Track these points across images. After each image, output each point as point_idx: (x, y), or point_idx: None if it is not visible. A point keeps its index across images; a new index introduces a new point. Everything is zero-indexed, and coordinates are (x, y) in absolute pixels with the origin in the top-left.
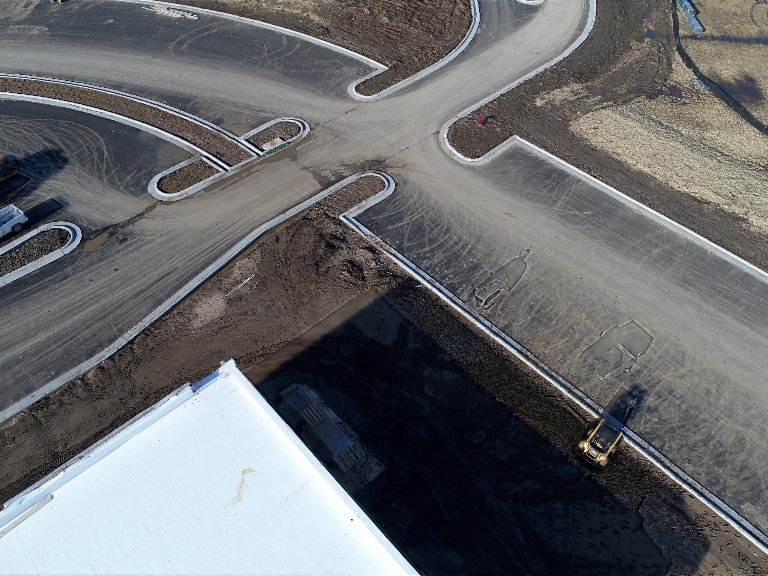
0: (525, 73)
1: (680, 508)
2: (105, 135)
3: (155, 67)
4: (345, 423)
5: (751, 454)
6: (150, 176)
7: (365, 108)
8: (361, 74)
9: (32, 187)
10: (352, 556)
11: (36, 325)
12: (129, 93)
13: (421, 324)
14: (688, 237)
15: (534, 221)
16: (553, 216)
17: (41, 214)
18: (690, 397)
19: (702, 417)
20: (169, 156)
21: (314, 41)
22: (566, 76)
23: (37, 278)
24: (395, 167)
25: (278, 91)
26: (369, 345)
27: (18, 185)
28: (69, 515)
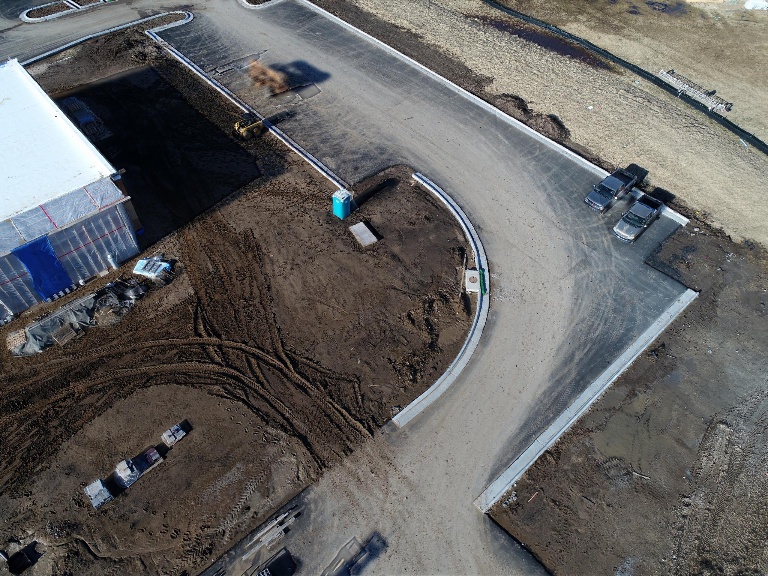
0: None
1: (285, 157)
2: None
3: None
4: (98, 117)
5: (346, 140)
6: (23, 10)
7: None
8: None
9: None
10: (49, 128)
11: None
12: None
13: (171, 80)
14: (379, 46)
15: (278, 37)
16: (293, 35)
17: None
18: (326, 116)
19: (327, 124)
20: (41, 0)
21: None
22: None
23: None
24: (198, 9)
25: None
26: (132, 88)
27: None
28: None
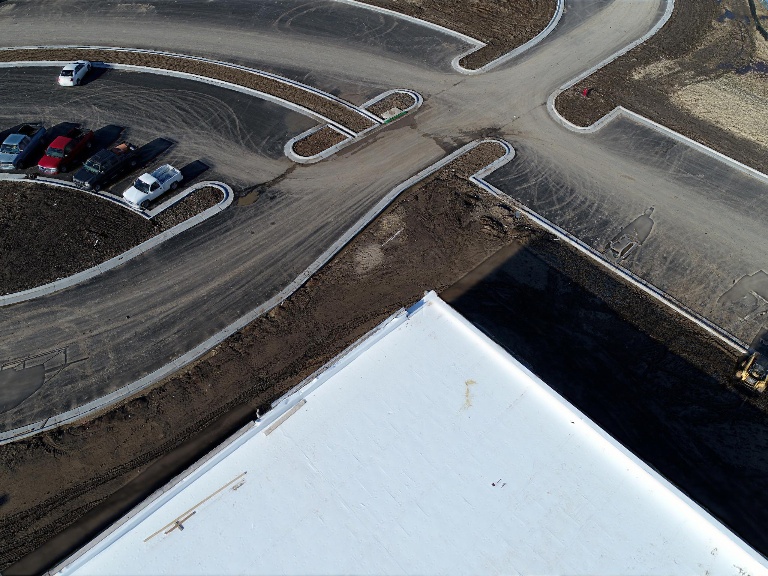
0: (617, 50)
1: None
2: (232, 104)
3: (264, 43)
4: (518, 355)
5: None
6: (283, 141)
7: (472, 81)
8: (461, 50)
9: (177, 150)
10: (580, 452)
11: (212, 271)
12: (246, 66)
13: (567, 272)
14: None
15: (652, 183)
16: (669, 179)
17: (191, 174)
18: None
19: None
20: (297, 123)
21: (410, 19)
22: (657, 52)
23: (202, 230)
24: (511, 134)
25: (386, 65)
26: (523, 289)
27: (163, 148)
28: (324, 416)
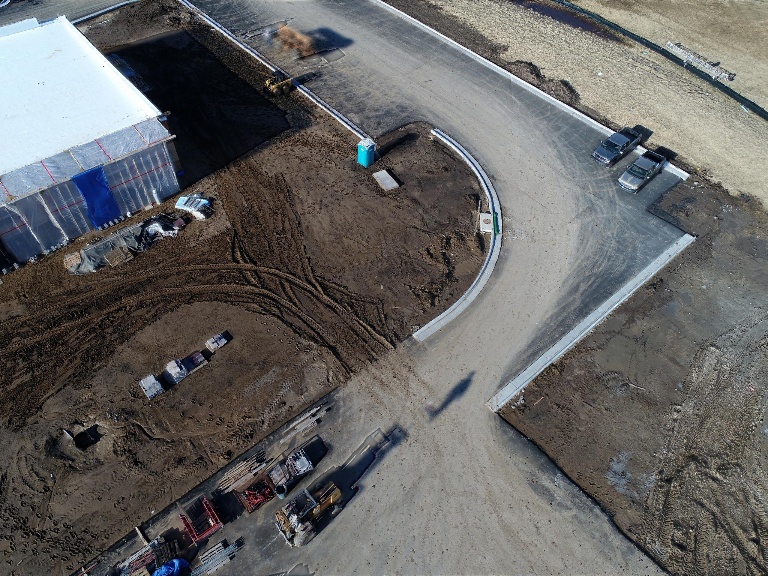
0: None
1: (312, 112)
2: None
3: None
4: (137, 73)
5: (369, 98)
6: None
7: None
8: None
9: None
10: (98, 76)
11: None
12: None
13: (204, 43)
14: (400, 16)
15: (304, 6)
16: (318, 4)
17: None
18: (350, 78)
19: (351, 85)
20: None
21: None
22: None
23: None
24: None
25: None
26: (168, 49)
27: None
28: None
